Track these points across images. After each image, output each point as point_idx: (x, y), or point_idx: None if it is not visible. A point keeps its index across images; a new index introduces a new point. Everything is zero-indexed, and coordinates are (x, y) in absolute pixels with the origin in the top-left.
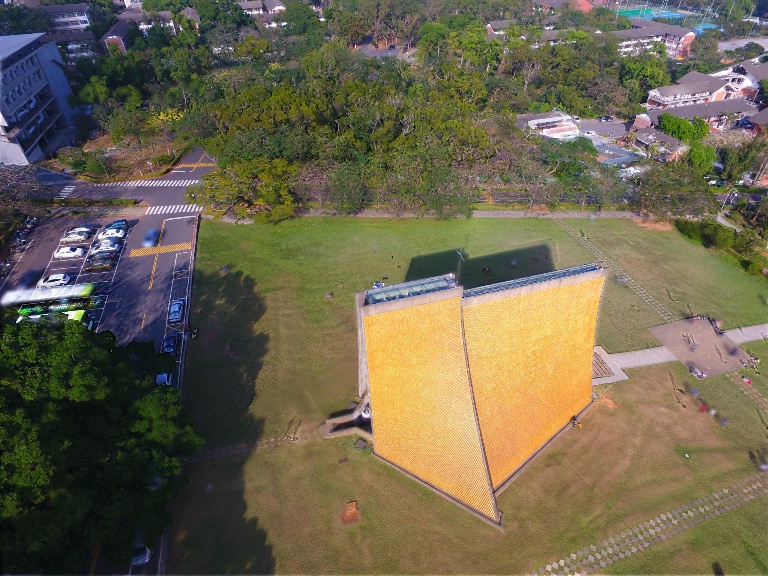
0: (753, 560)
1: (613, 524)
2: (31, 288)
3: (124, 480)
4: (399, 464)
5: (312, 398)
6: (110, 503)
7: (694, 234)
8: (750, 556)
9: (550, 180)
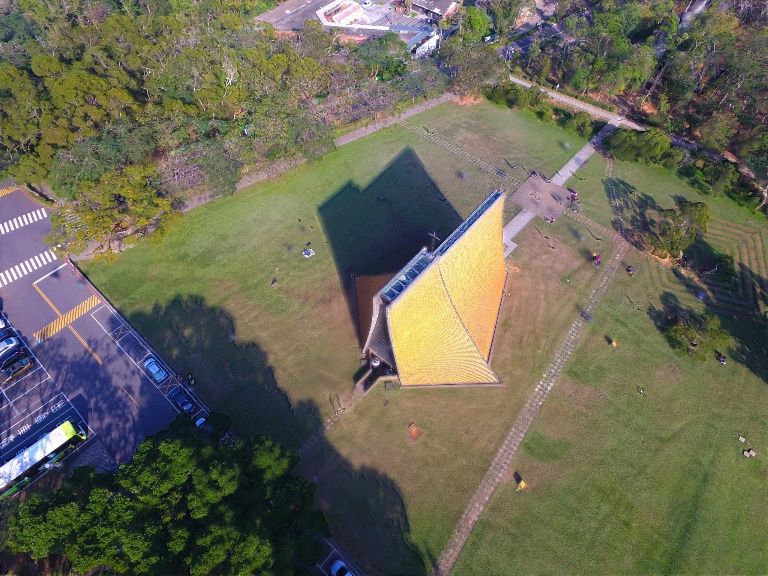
0: (619, 323)
1: (554, 345)
2: None
3: (287, 515)
4: (423, 383)
5: (330, 374)
6: (298, 533)
7: (500, 100)
8: (617, 322)
9: (387, 91)
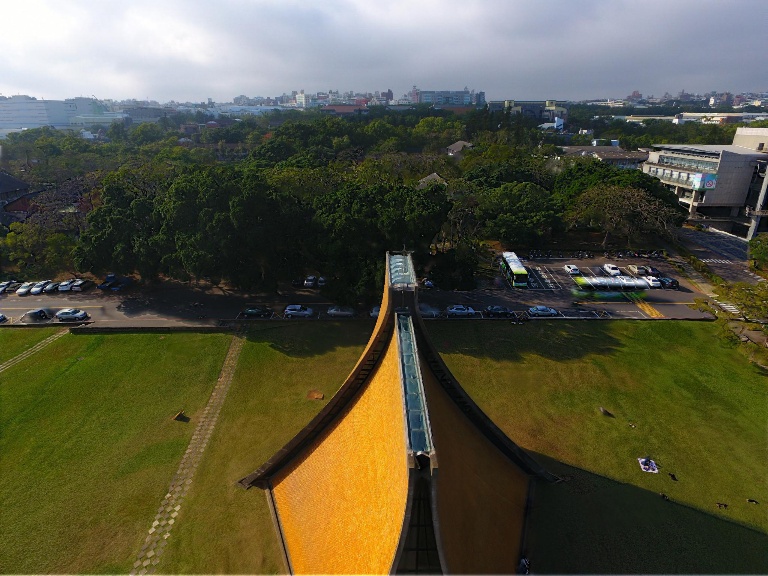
0: None
1: None
2: (563, 265)
3: None
4: None
5: None
6: None
7: None
8: None
9: None
